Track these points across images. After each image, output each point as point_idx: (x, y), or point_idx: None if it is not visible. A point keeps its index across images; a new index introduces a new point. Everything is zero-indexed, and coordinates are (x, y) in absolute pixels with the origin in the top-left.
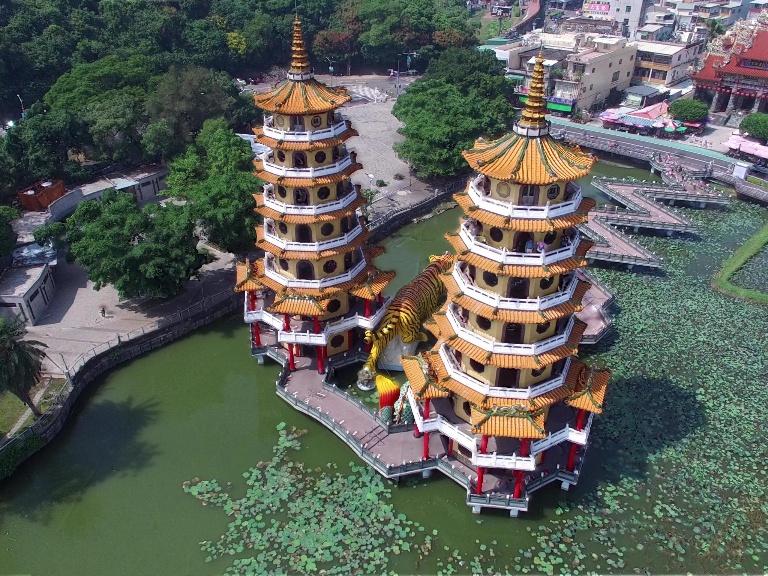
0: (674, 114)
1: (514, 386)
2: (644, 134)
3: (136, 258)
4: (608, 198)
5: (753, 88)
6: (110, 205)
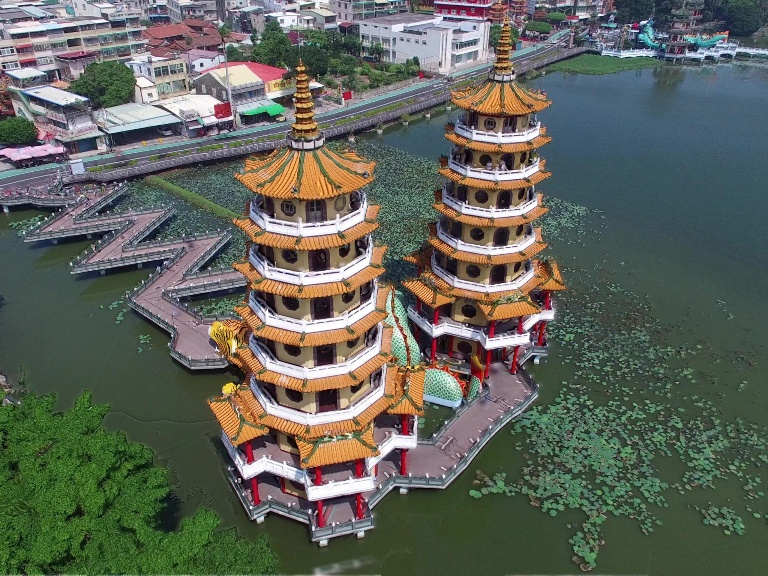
0: None
1: None
2: None
3: None
4: (52, 244)
5: None
6: None
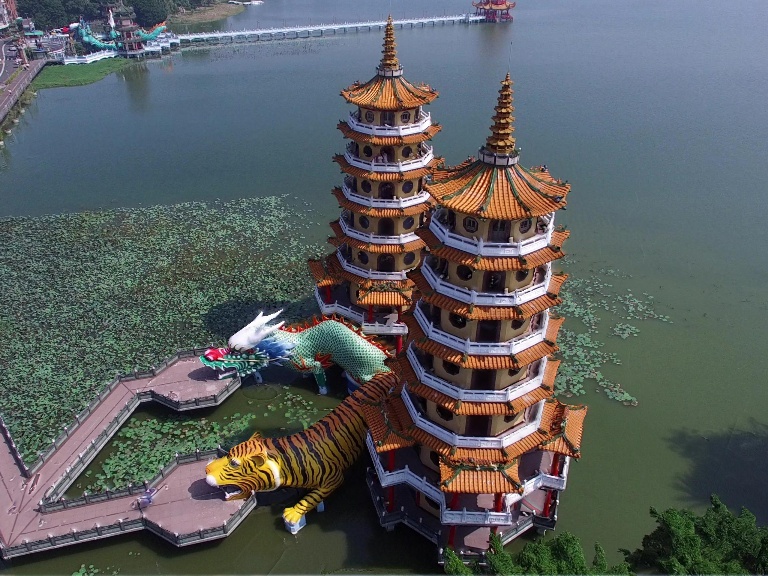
0: None
1: None
2: None
3: None
4: None
5: None
6: None
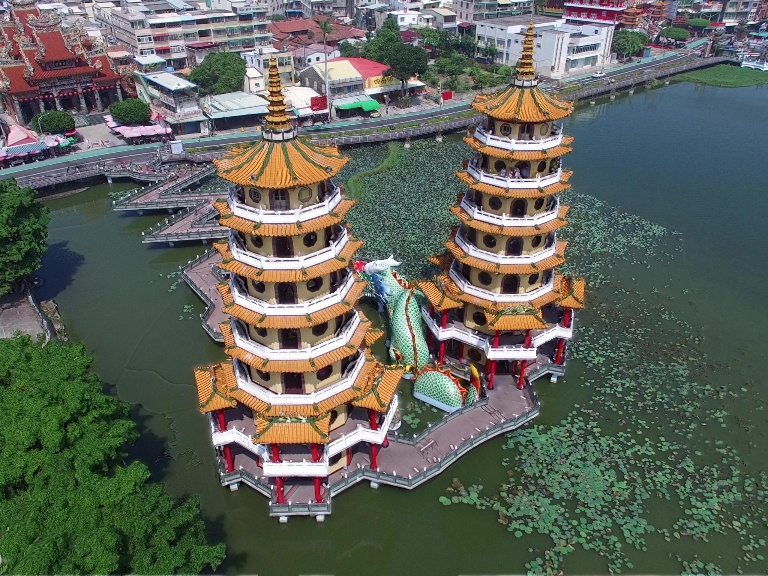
0: (51, 129)
1: (543, 276)
2: (42, 159)
3: (172, 574)
4: (138, 215)
5: (71, 87)
6: (30, 575)
